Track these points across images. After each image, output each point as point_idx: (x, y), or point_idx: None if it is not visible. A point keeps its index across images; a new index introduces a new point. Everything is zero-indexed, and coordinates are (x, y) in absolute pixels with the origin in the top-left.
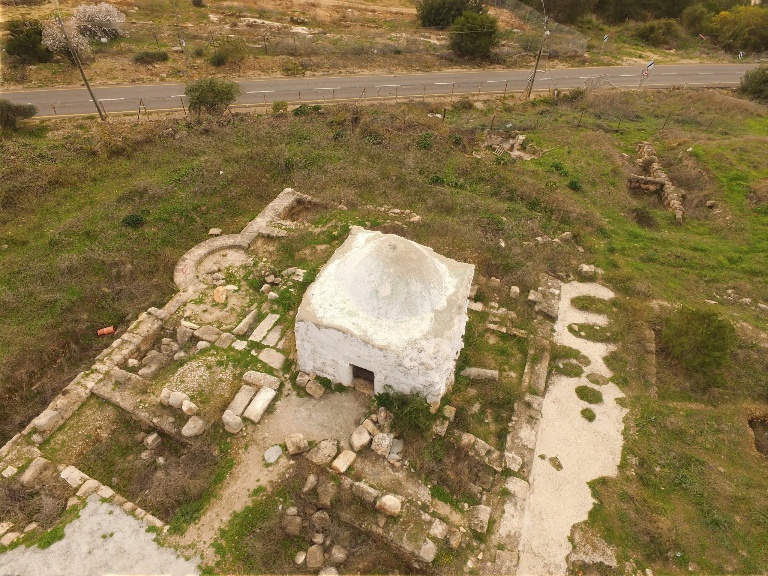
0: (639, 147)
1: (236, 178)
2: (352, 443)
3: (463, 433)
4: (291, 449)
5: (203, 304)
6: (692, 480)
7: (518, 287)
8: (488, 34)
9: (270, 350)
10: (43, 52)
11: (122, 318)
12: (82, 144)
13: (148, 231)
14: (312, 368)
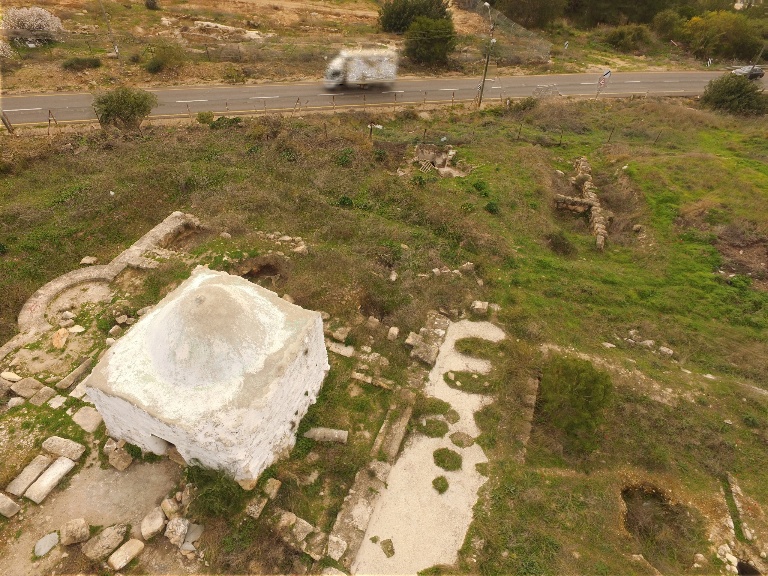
0: (576, 163)
1: (126, 199)
2: (141, 530)
3: (284, 512)
4: (63, 540)
5: (38, 350)
6: (539, 569)
7: (398, 328)
8: (444, 40)
9: (88, 409)
10: None
11: None
12: None
13: (9, 261)
14: (121, 434)
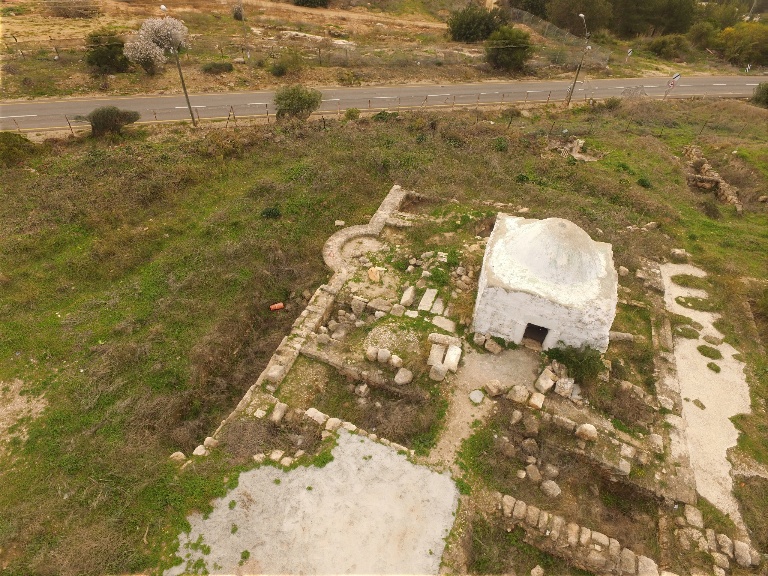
0: (686, 150)
1: (344, 177)
2: (540, 387)
3: (621, 381)
4: (495, 391)
5: (362, 282)
6: None
7: (625, 267)
8: (522, 48)
9: (440, 317)
10: (119, 62)
11: (287, 296)
12: (194, 147)
13: (285, 222)
14: (487, 330)
